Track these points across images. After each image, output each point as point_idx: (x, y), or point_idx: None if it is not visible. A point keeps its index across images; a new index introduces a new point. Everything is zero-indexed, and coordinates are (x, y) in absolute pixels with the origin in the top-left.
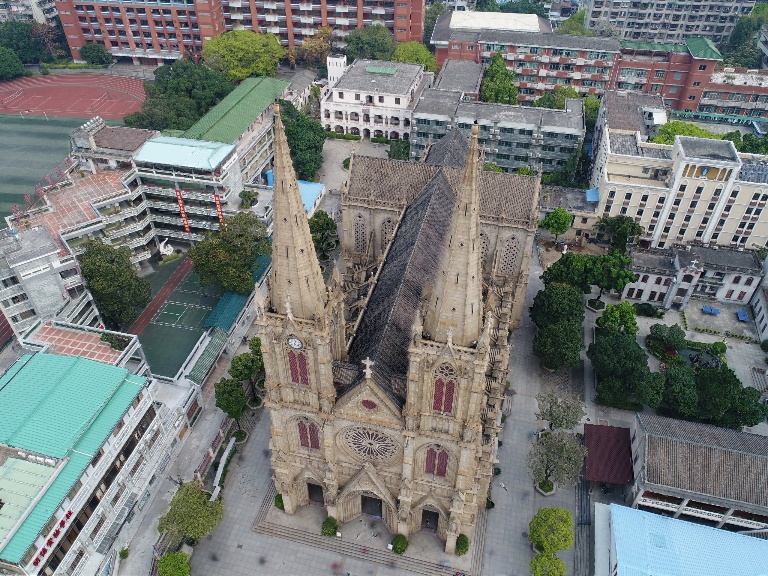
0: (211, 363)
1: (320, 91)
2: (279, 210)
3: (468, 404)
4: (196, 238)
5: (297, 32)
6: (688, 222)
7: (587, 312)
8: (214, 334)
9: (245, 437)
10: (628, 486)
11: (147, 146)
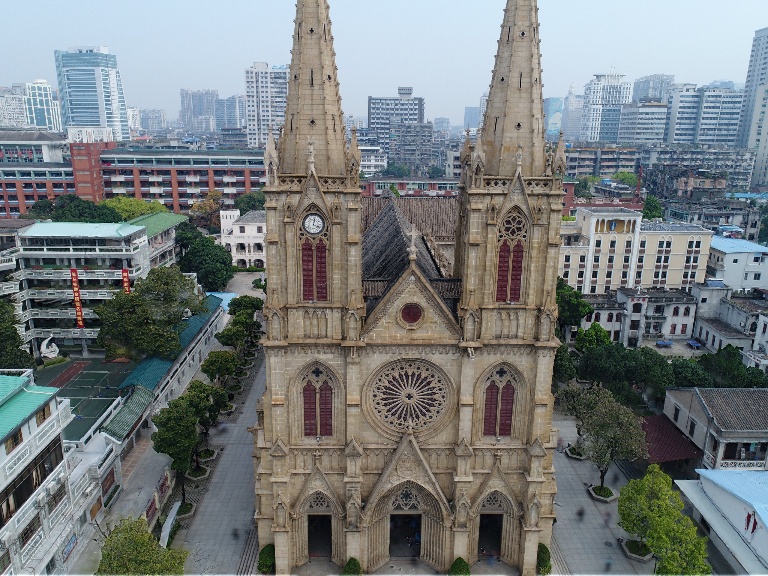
0: (134, 421)
1: (214, 242)
2: (304, 18)
3: (542, 276)
4: (91, 334)
5: (183, 202)
6: (610, 278)
7: None
8: (135, 391)
9: (191, 508)
10: (694, 468)
11: (37, 226)
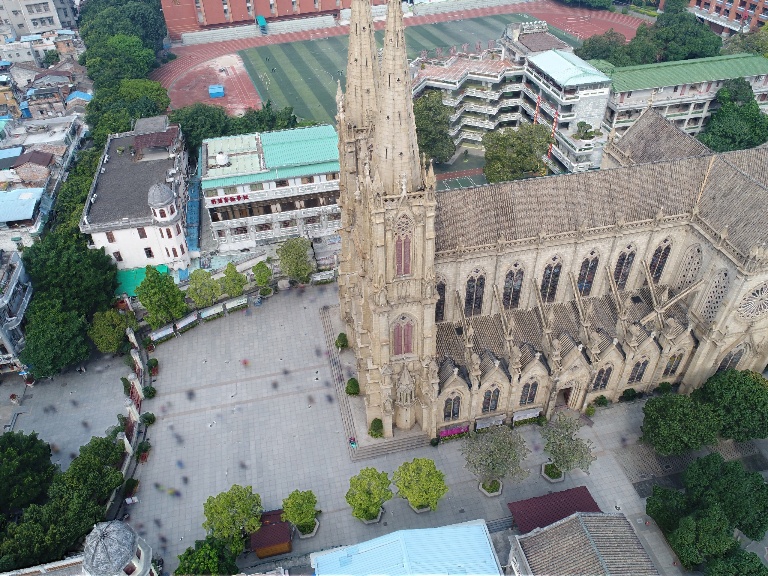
0: None
1: None
2: None
3: None
4: None
5: None
6: None
7: None
8: None
9: None
10: None
11: (547, 53)
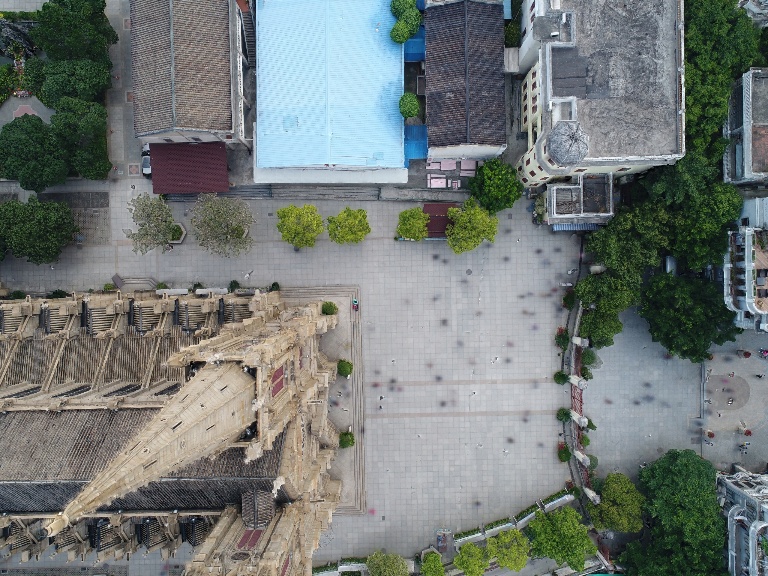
0: None
1: None
2: None
3: None
4: None
5: None
6: None
7: None
8: None
9: None
10: None
11: None
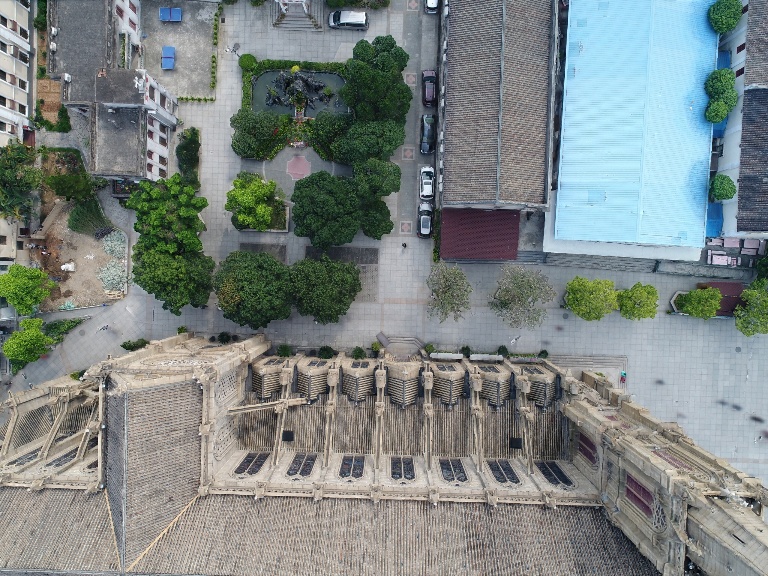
0: None
1: None
2: None
3: None
4: None
5: None
6: None
7: (207, 237)
8: None
9: None
10: None
11: None
